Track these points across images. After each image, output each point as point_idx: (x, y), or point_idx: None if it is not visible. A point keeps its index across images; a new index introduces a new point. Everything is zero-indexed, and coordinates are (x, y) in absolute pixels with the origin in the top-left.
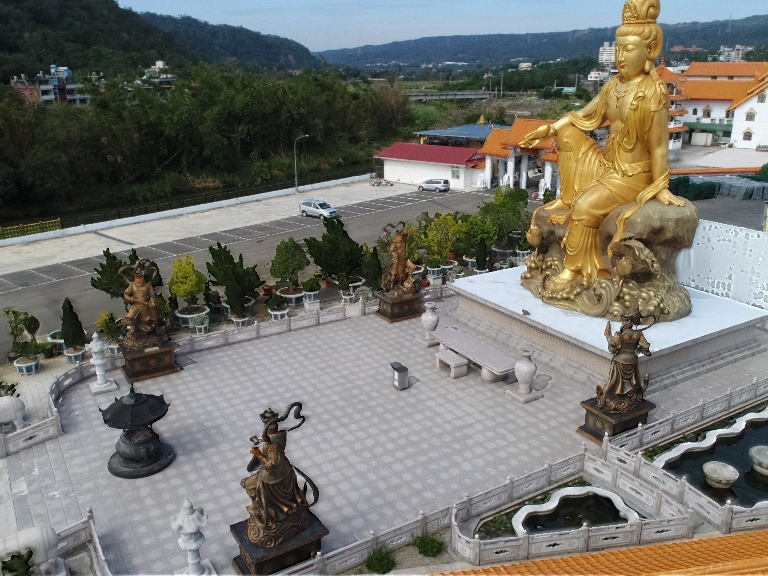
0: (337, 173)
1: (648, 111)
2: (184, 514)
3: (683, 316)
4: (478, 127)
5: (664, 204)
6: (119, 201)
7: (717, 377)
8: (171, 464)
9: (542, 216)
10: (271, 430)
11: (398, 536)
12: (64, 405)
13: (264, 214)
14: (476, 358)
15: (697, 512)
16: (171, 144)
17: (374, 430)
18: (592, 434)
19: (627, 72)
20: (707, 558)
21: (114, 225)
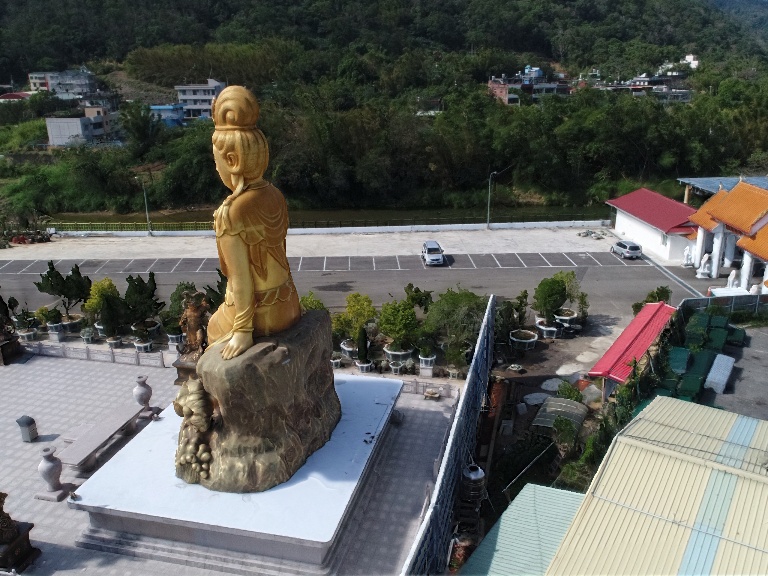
0: (551, 214)
1: None
2: None
3: (234, 491)
4: (759, 182)
5: None
6: (438, 205)
7: None
8: None
9: None
10: None
11: None
12: None
13: (401, 247)
14: (75, 441)
15: None
16: None
17: None
18: None
19: None
20: None
21: None
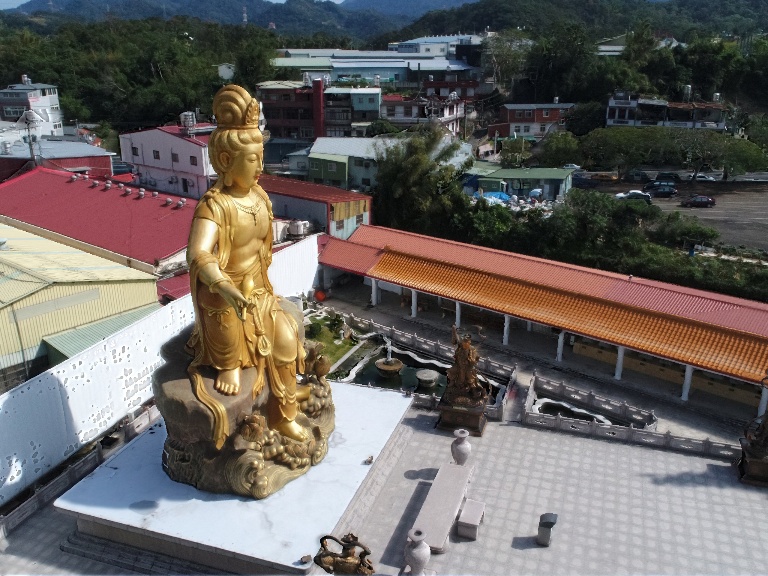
0: None
1: None
2: None
3: None
4: None
5: (281, 301)
6: None
7: None
8: None
9: (245, 400)
10: None
11: (687, 443)
12: None
13: None
14: None
15: None
16: None
17: (623, 517)
18: None
19: None
20: (618, 325)
21: None
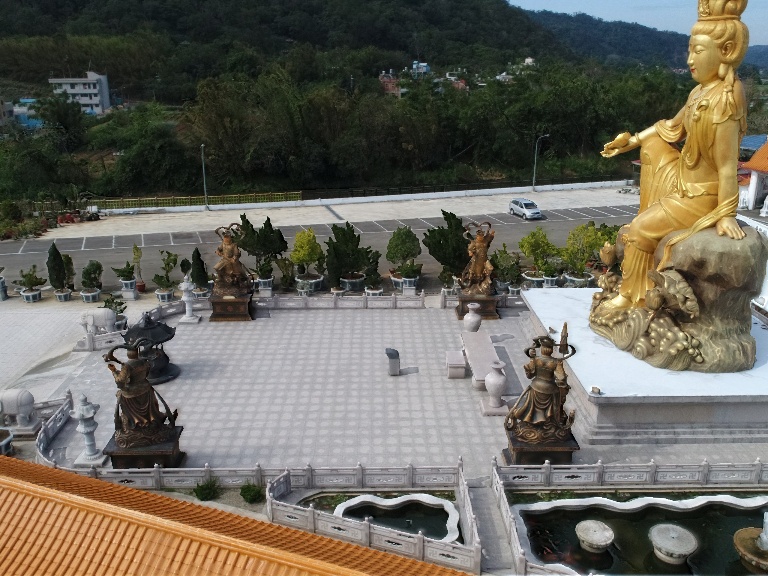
0: (585, 176)
1: (710, 123)
2: (80, 404)
3: (729, 371)
4: None
5: (717, 234)
6: None
7: (741, 450)
8: (167, 382)
9: (619, 234)
10: (129, 355)
11: (234, 477)
12: None
13: (478, 208)
14: (471, 363)
15: (513, 556)
16: (467, 137)
17: (329, 400)
18: (507, 458)
19: (698, 77)
20: (321, 555)
21: (346, 202)
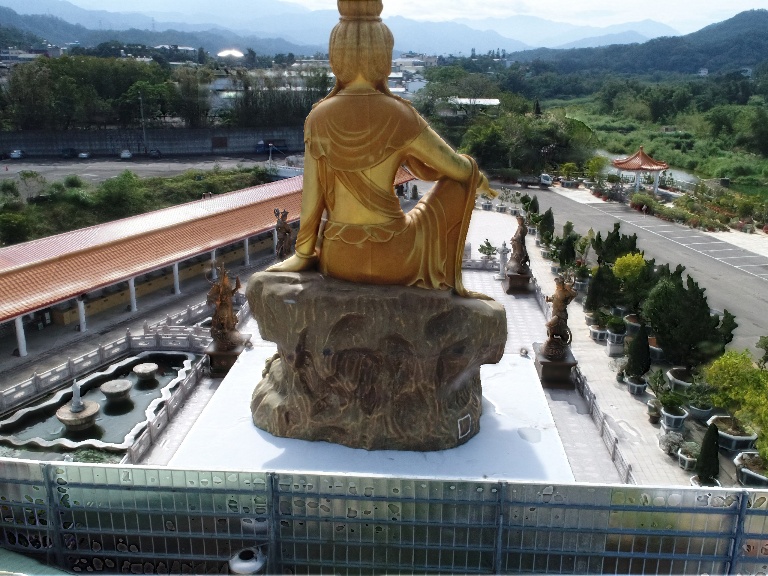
0: None
1: None
2: None
3: None
4: None
5: None
6: None
7: None
8: None
9: None
10: None
11: None
12: (489, 271)
13: None
14: None
15: None
16: None
17: None
18: None
19: None
20: (119, 262)
21: None
